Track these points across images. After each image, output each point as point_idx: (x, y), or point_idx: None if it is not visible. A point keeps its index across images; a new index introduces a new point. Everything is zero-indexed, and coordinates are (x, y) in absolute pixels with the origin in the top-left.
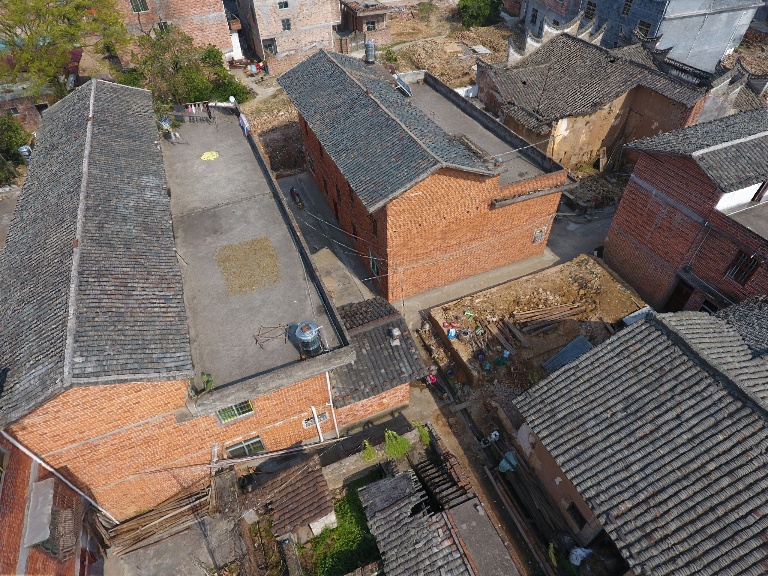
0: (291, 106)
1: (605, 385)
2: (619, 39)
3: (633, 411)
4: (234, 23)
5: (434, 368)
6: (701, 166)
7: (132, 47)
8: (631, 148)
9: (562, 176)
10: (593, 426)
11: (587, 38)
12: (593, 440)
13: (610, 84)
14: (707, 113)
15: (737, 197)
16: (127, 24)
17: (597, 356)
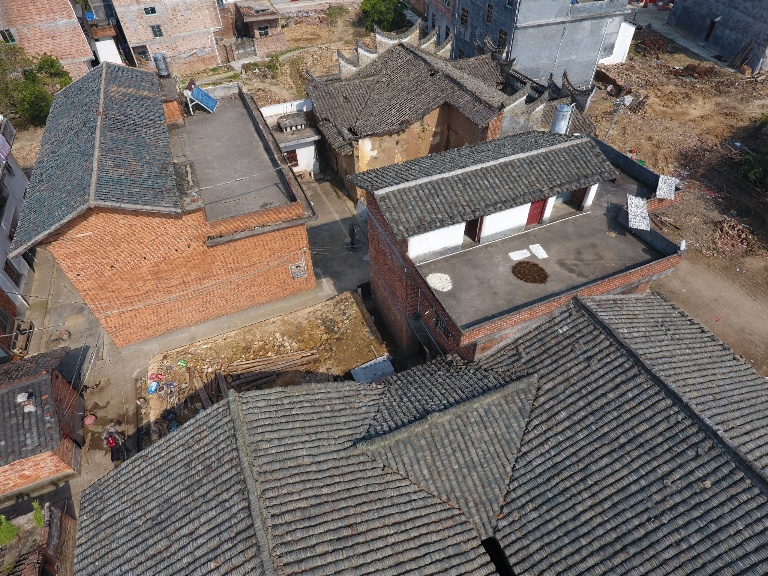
0: None
1: (157, 482)
2: (475, 48)
3: (163, 519)
4: (107, 29)
5: (113, 430)
6: (380, 207)
7: None
8: (349, 180)
9: (295, 209)
10: (123, 535)
11: (433, 48)
12: (112, 555)
13: (422, 100)
14: (509, 133)
15: (436, 240)
16: None
17: (168, 443)
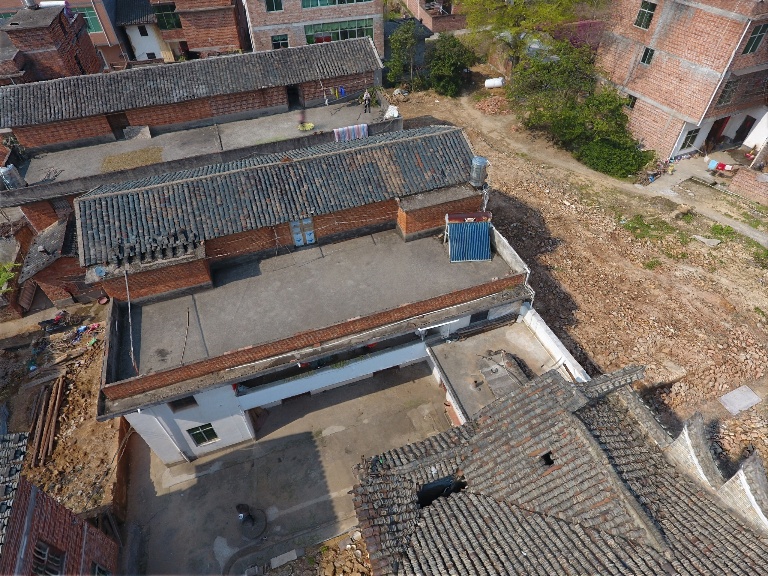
0: (607, 213)
1: None
2: None
3: None
4: None
5: (60, 314)
6: None
7: (610, 58)
8: None
9: None
10: None
11: None
12: None
13: None
14: None
15: None
16: (621, 33)
17: None
